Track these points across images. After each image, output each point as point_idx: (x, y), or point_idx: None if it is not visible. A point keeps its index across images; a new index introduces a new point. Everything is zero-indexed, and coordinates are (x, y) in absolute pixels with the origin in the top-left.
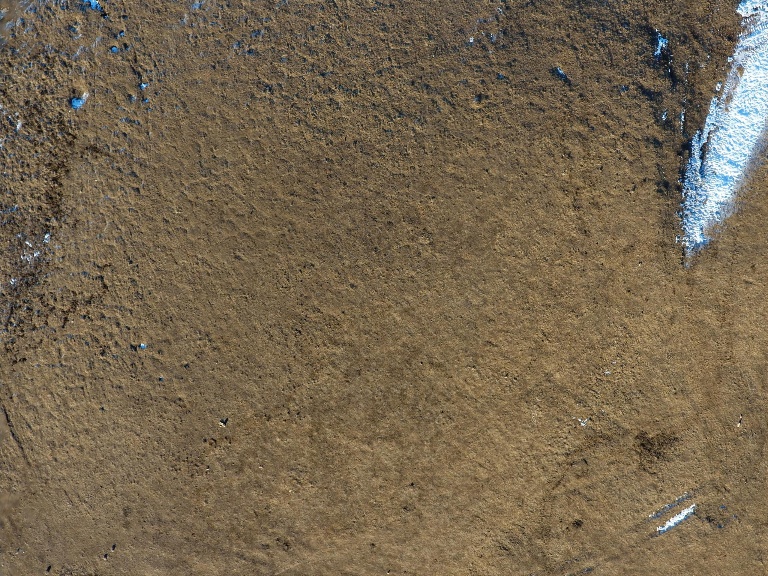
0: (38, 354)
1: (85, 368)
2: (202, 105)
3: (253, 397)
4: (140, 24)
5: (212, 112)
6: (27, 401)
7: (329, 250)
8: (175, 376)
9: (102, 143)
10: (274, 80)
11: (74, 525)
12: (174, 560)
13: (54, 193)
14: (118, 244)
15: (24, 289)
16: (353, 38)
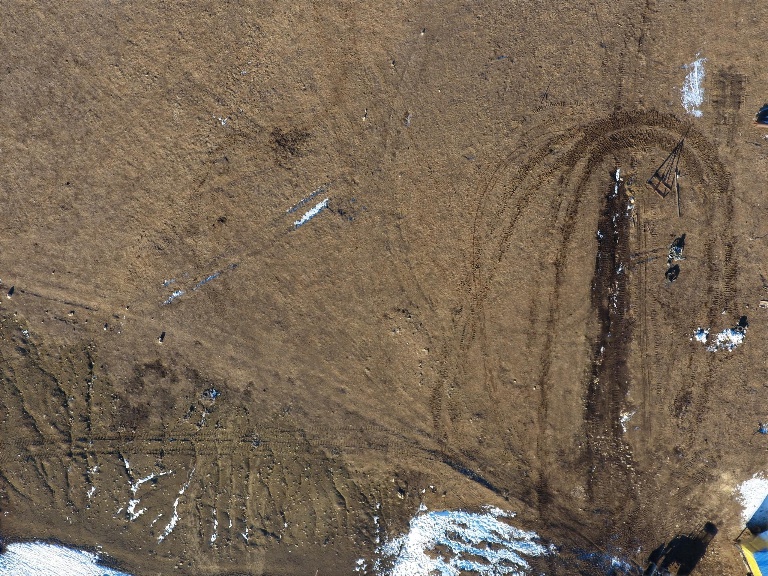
0: None
1: None
2: None
3: None
4: None
5: None
6: None
7: None
8: None
9: None
10: None
11: None
12: None
13: None
14: None
15: None
16: None
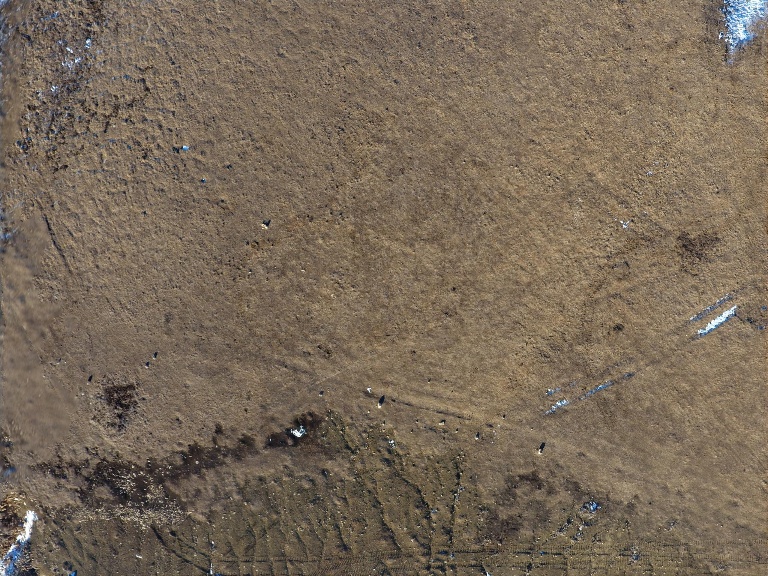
0: (80, 160)
1: (127, 172)
2: None
3: (296, 197)
4: None
5: None
6: (68, 208)
7: (373, 46)
8: (218, 177)
9: None
10: None
11: (116, 333)
12: (216, 367)
13: None
14: (160, 45)
15: (65, 95)
16: None
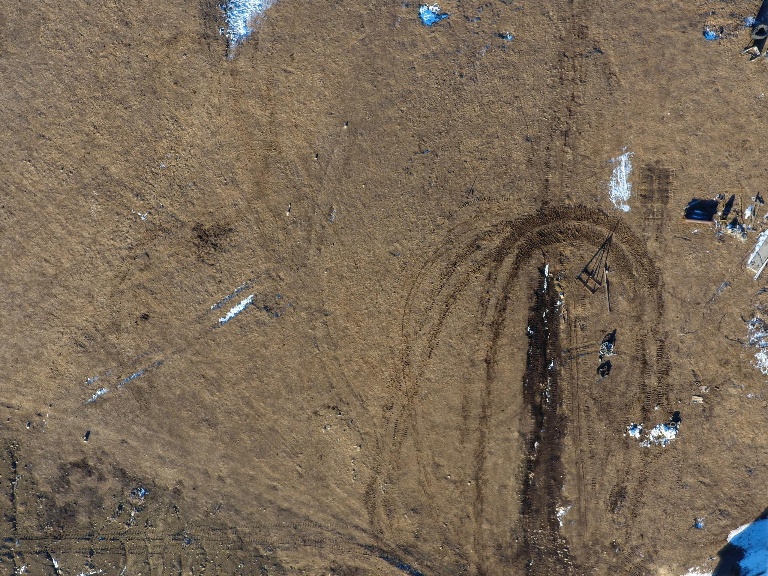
0: None
1: None
2: None
3: None
4: None
5: None
6: None
7: None
8: None
9: None
10: None
11: None
12: None
13: None
14: None
15: None
16: None
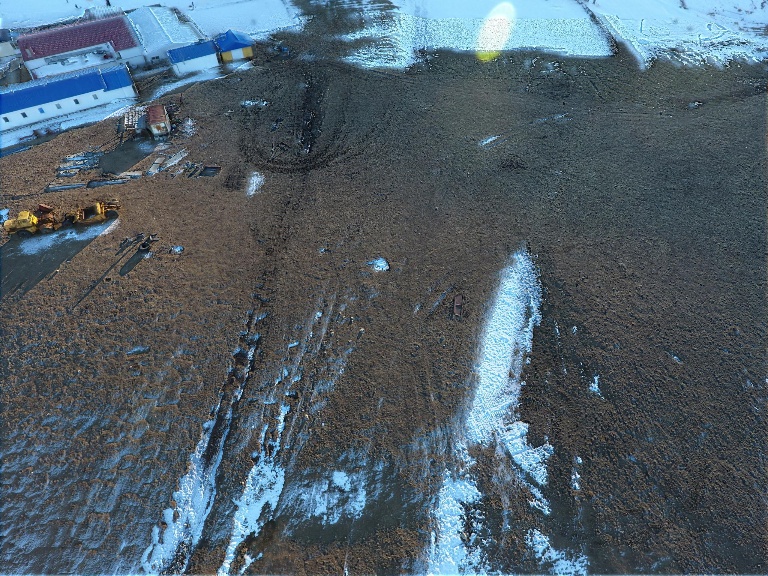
0: None
1: None
2: None
3: None
4: None
5: None
6: None
7: None
8: None
9: None
10: None
11: None
12: (764, 117)
13: None
14: None
15: None
16: None
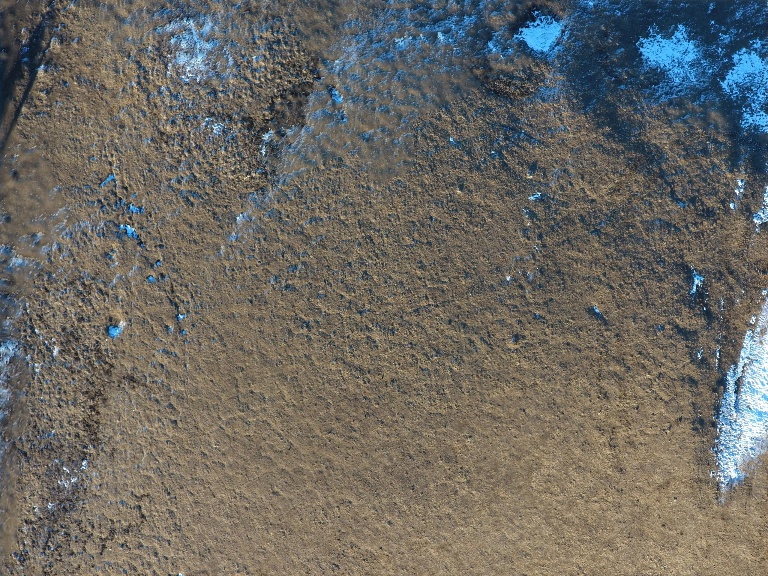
0: None
1: None
2: (239, 339)
3: None
4: (176, 254)
5: (249, 347)
6: None
7: (367, 487)
8: None
9: (139, 373)
10: (311, 316)
11: None
12: None
13: (91, 421)
14: (156, 475)
15: (62, 514)
16: (390, 276)
